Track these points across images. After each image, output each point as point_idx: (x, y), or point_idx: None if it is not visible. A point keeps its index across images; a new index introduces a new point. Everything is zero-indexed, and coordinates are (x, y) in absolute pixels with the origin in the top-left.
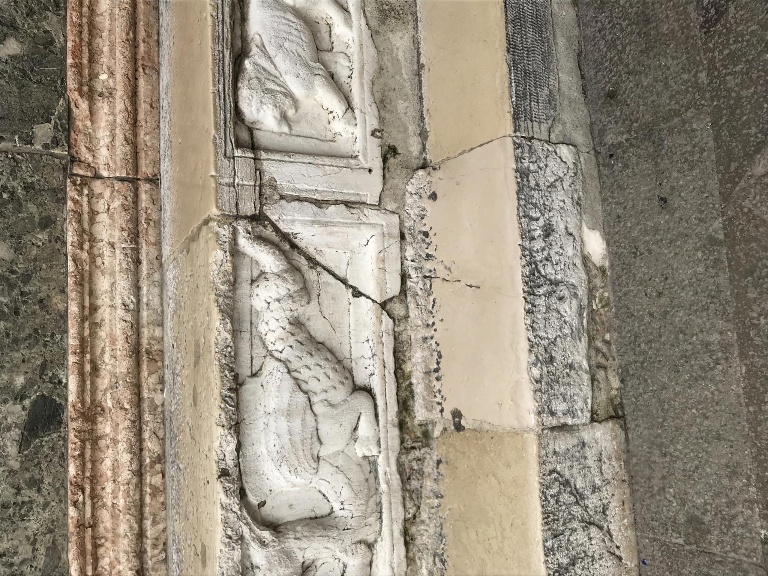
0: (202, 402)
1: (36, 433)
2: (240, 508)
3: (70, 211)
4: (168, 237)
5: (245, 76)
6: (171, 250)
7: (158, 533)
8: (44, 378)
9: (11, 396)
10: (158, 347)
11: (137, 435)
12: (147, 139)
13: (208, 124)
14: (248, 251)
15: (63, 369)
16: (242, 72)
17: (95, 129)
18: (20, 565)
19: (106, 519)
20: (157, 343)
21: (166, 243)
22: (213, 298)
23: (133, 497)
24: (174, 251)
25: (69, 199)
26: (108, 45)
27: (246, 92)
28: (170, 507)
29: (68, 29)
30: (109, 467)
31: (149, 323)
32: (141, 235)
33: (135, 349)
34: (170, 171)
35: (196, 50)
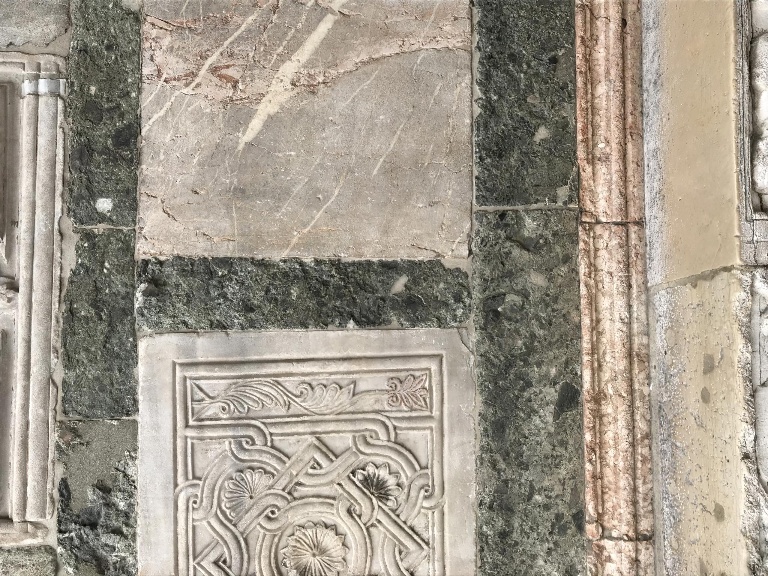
0: (719, 402)
1: (563, 408)
2: (758, 483)
3: (582, 250)
4: (658, 269)
5: (759, 155)
6: (664, 280)
7: (647, 490)
8: (567, 370)
9: (548, 382)
10: (645, 351)
11: (631, 416)
12: (635, 191)
13: (731, 196)
14: (760, 291)
15: (578, 364)
16: (756, 152)
17: (596, 186)
18: (556, 498)
19: (609, 475)
20: (644, 348)
21: (655, 273)
22: (737, 327)
23: (630, 461)
24: (670, 281)
25: (581, 241)
26: (605, 121)
27: (761, 168)
28: (659, 473)
29: (578, 113)
30: (611, 438)
31: (638, 333)
32: (631, 266)
33: (629, 352)
34: (662, 218)
35: (711, 135)
